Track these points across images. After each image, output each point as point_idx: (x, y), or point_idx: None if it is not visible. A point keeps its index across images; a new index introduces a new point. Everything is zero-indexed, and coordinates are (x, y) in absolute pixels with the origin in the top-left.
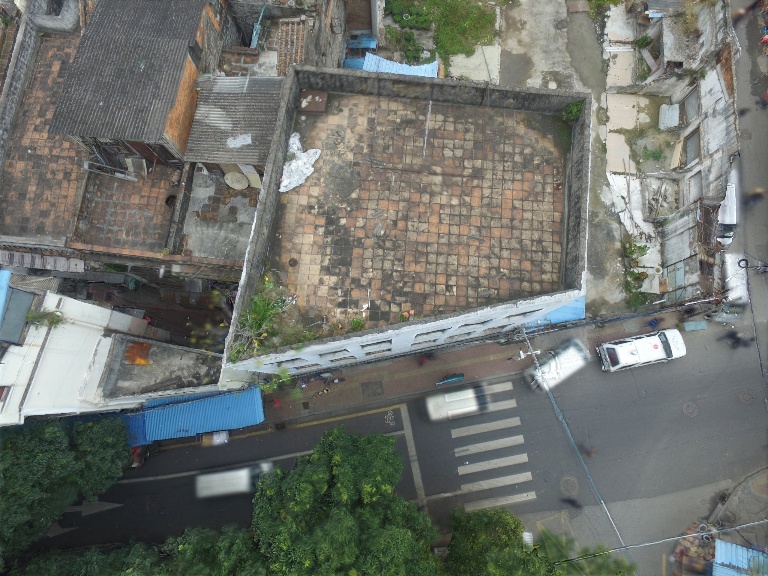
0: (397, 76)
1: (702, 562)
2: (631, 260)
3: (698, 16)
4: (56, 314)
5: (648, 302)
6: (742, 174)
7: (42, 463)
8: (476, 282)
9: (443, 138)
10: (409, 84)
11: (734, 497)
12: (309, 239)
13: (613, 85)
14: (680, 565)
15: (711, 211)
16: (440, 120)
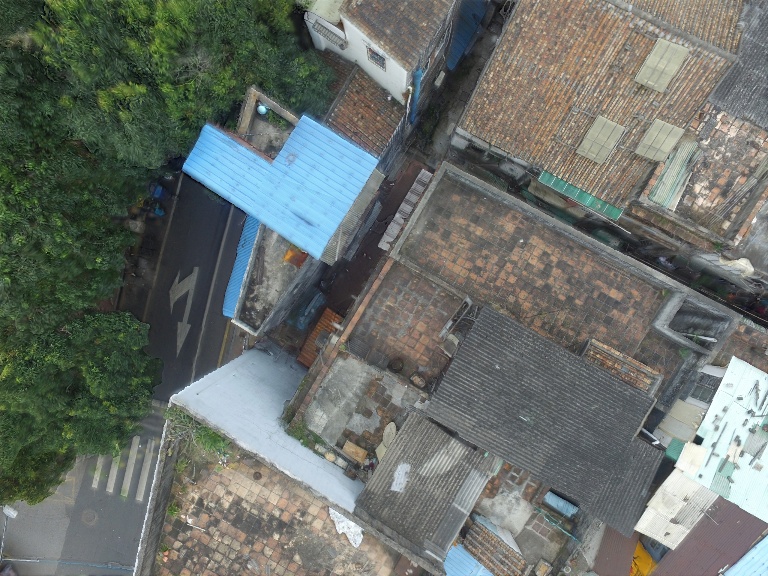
0: None
1: None
2: None
3: None
4: None
5: None
6: None
7: None
8: None
9: None
10: None
11: None
12: (273, 499)
13: None
14: None
15: None
16: None
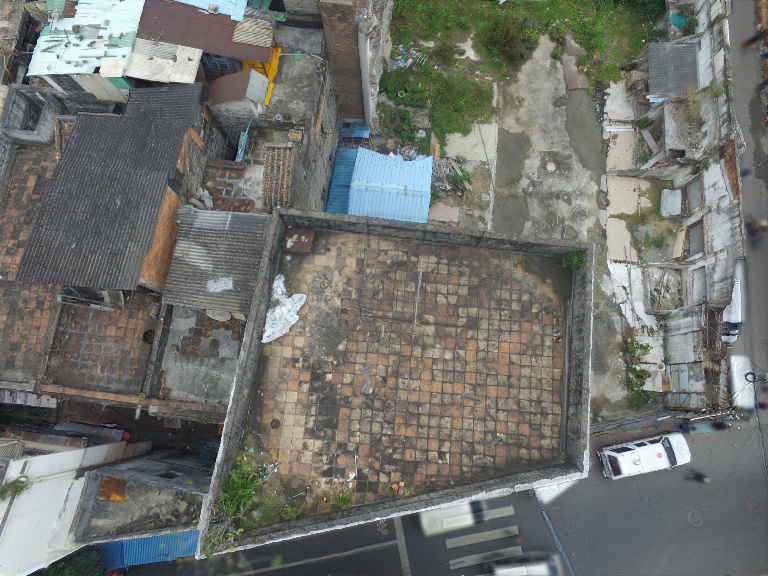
0: (387, 222)
1: None
2: (633, 356)
3: (700, 103)
4: (20, 480)
5: (651, 401)
6: (746, 262)
7: None
8: (471, 448)
9: (436, 282)
10: (400, 229)
11: None
12: (293, 397)
13: (613, 169)
14: None
15: (716, 313)
16: (433, 262)
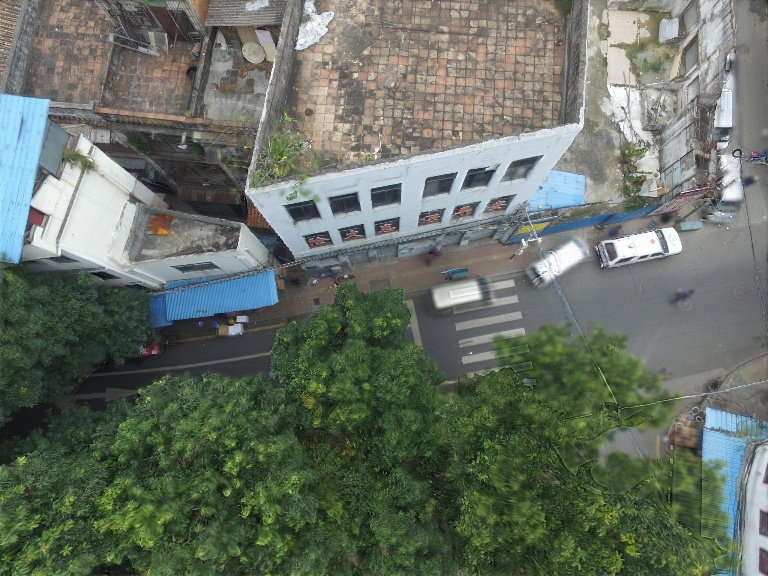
0: None
1: (693, 429)
2: (630, 165)
3: None
4: (88, 160)
5: (646, 205)
6: (739, 86)
7: (75, 309)
8: (481, 128)
9: (450, 1)
10: None
11: (726, 384)
12: (324, 91)
13: (614, 0)
14: (672, 434)
15: (707, 111)
16: None
